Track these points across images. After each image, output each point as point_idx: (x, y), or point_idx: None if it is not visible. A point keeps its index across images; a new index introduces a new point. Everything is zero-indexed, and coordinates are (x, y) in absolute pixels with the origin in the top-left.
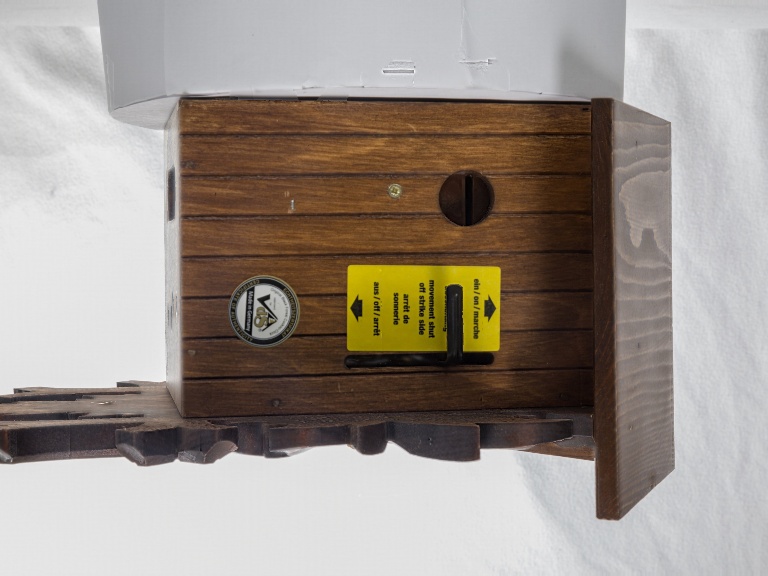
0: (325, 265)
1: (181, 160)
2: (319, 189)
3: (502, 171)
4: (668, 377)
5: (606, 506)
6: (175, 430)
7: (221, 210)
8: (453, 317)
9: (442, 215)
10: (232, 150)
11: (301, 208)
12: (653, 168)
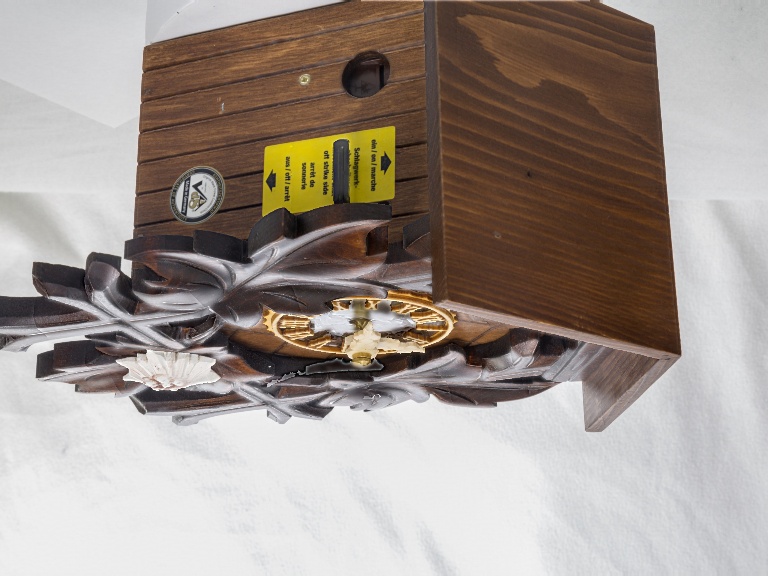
0: (247, 150)
1: (142, 90)
2: (244, 91)
3: (397, 46)
4: (650, 253)
5: (437, 289)
6: (84, 271)
7: (169, 121)
8: (339, 166)
9: (345, 92)
10: (179, 74)
11: (230, 108)
12: (584, 41)
